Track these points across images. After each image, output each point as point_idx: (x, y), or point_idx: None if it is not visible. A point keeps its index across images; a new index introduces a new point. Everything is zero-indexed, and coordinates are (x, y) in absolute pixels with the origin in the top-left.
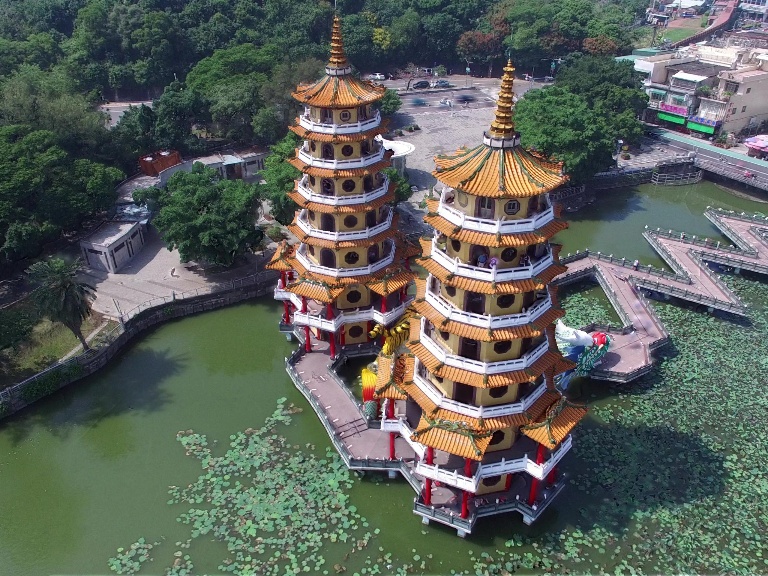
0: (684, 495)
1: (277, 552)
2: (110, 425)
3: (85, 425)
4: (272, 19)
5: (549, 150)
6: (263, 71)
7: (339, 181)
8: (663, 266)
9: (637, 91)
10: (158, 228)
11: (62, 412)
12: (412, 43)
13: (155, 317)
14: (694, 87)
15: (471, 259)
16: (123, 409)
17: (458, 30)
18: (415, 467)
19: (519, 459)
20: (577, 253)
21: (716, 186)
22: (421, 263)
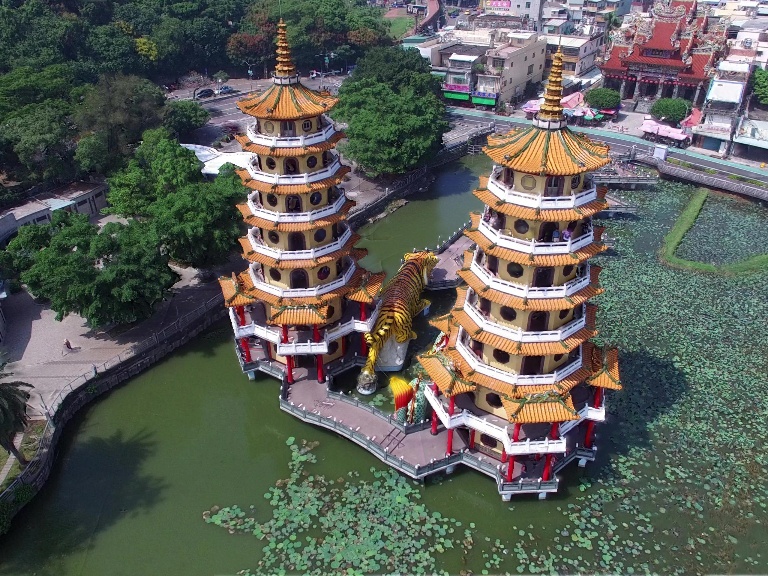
0: (668, 399)
1: None
2: (110, 539)
3: (77, 551)
4: (9, 37)
5: (401, 137)
6: (54, 97)
7: (307, 195)
8: None
9: (432, 75)
10: (48, 296)
11: (32, 548)
12: (179, 51)
13: (78, 401)
14: (470, 66)
15: (544, 237)
16: (115, 515)
17: (224, 33)
18: (473, 454)
19: (582, 410)
20: (465, 226)
21: None
22: (491, 252)
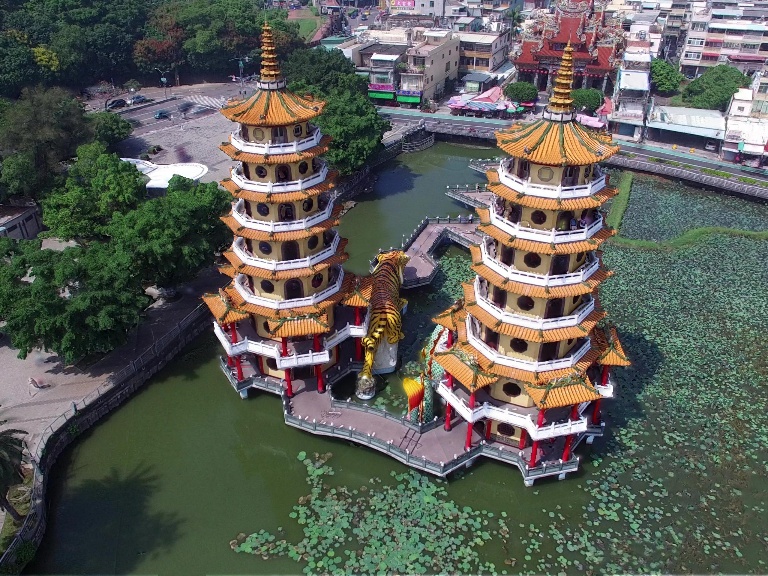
0: (648, 370)
1: None
2: None
3: None
4: None
5: (346, 139)
6: None
7: (301, 202)
8: (475, 215)
9: (358, 75)
10: (13, 333)
11: None
12: None
13: (59, 444)
14: (392, 65)
15: (562, 226)
16: (134, 560)
17: (130, 40)
18: (491, 445)
19: None
20: (422, 223)
21: (449, 144)
22: (513, 245)
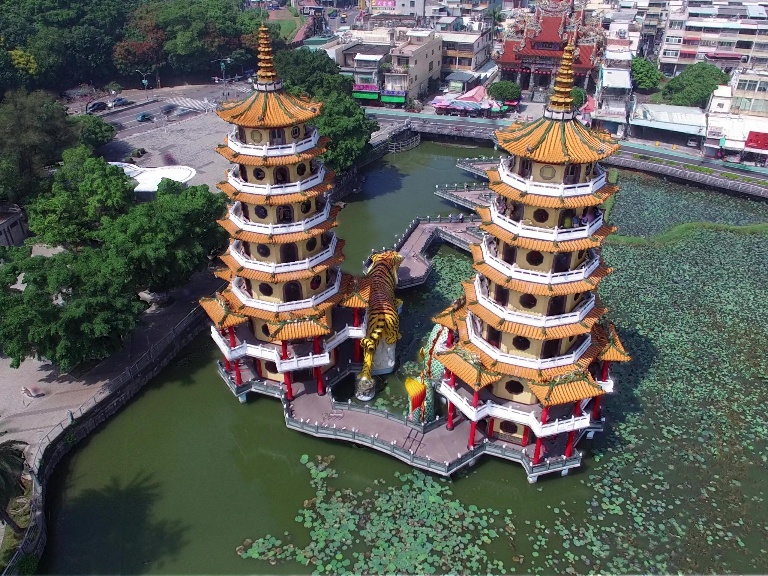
0: (643, 365)
1: None
2: None
3: None
4: None
5: (335, 140)
6: None
7: (299, 204)
8: (465, 214)
9: (343, 76)
10: (6, 342)
11: None
12: None
13: (56, 453)
14: (376, 65)
15: (564, 224)
16: (139, 569)
17: (109, 42)
18: (493, 443)
19: None
20: (414, 223)
21: (435, 144)
22: (516, 243)
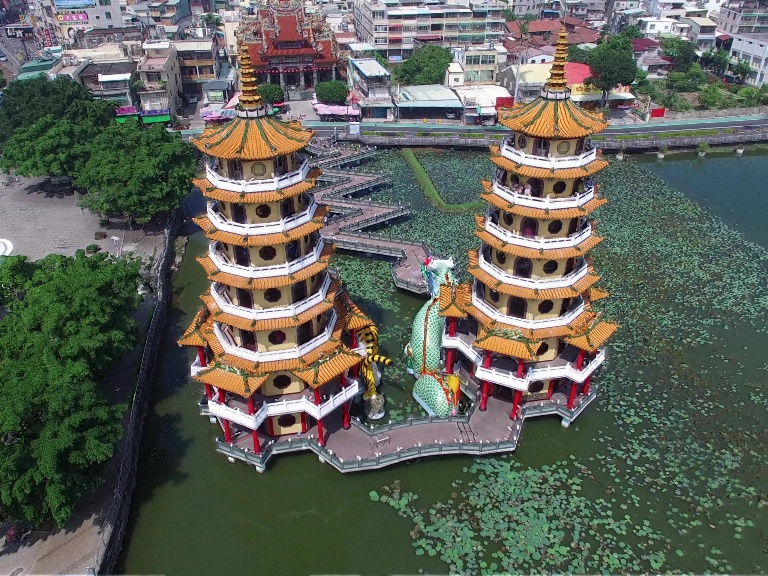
0: None
1: (590, 532)
2: None
3: None
4: None
5: None
6: None
7: None
8: None
9: None
10: None
11: None
12: None
13: None
14: (127, 85)
15: (579, 190)
16: None
17: None
18: (526, 406)
19: None
20: None
21: None
22: None
